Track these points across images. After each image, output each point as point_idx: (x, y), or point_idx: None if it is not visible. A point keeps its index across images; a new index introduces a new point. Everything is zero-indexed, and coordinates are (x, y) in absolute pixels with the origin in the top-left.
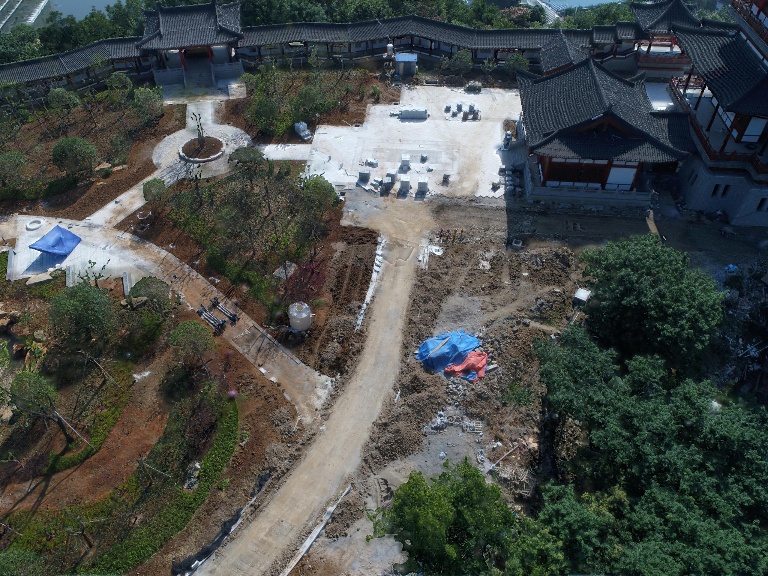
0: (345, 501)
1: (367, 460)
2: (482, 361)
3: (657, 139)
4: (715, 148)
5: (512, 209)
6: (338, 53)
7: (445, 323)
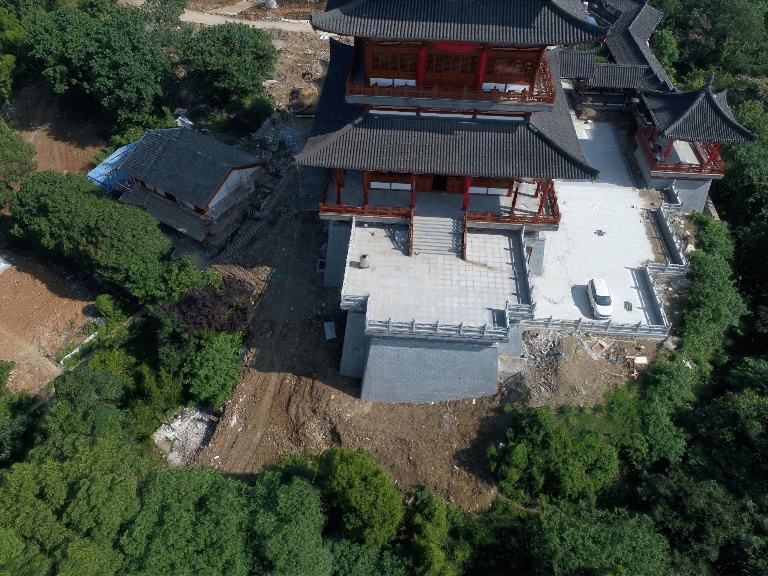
0: None
1: None
2: None
3: None
4: None
5: None
6: (601, 6)
7: None
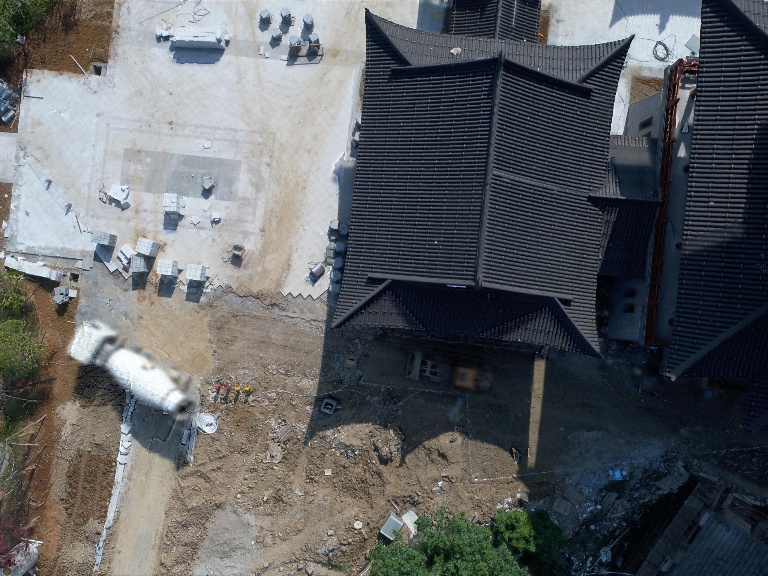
0: None
1: None
2: None
3: (563, 310)
4: (669, 305)
5: None
6: None
7: (209, 559)
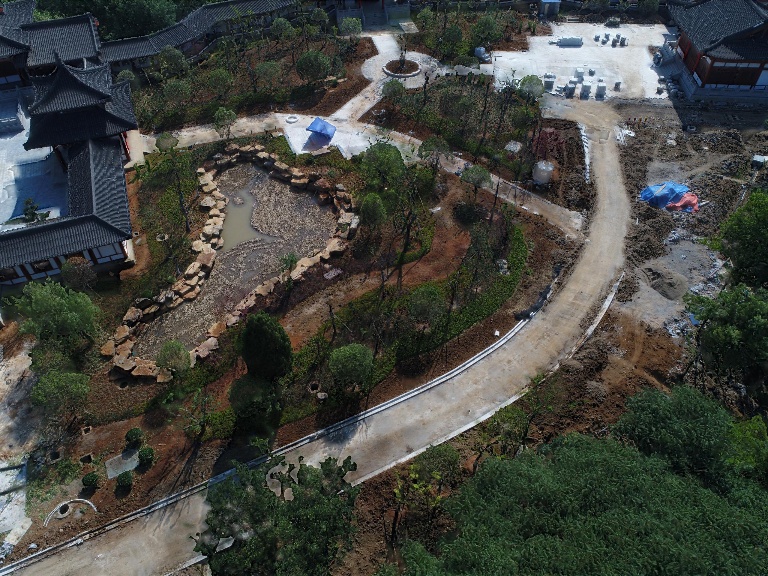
0: (626, 279)
1: (630, 258)
2: (695, 200)
3: None
4: None
5: (679, 106)
6: None
7: (654, 179)
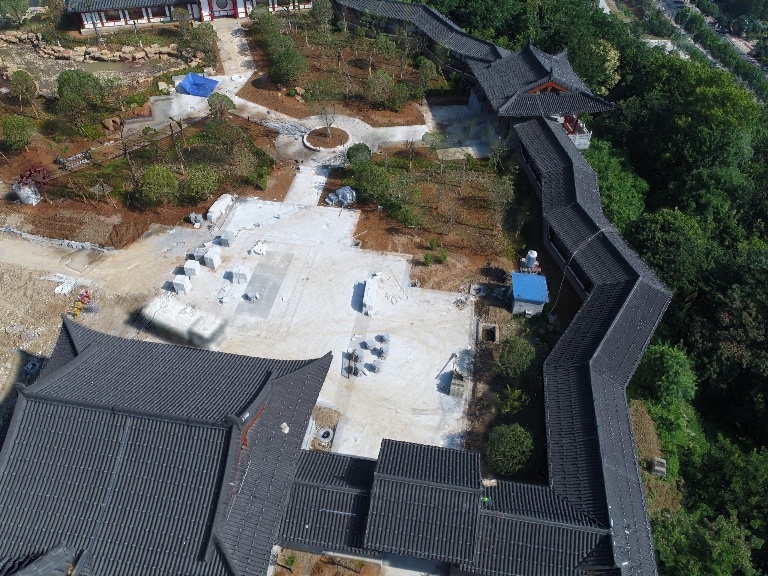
0: None
1: None
2: None
3: None
4: None
5: None
6: None
7: None
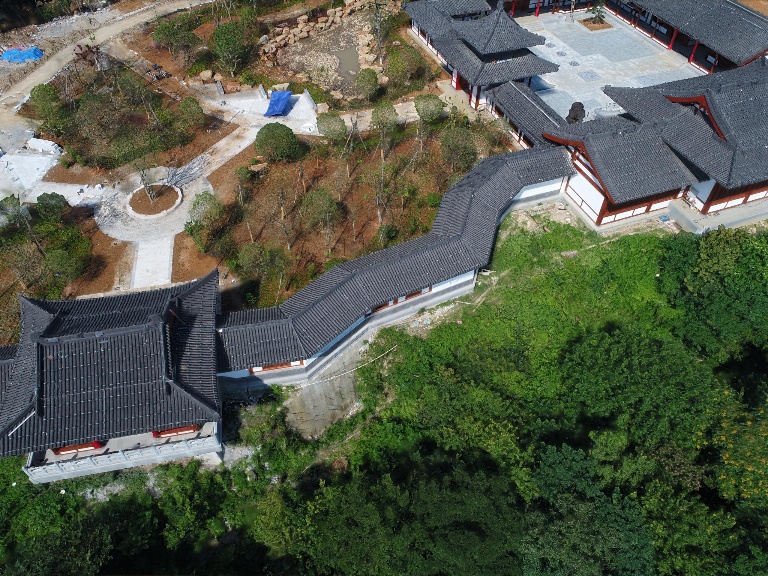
0: None
1: None
2: None
3: None
4: None
5: None
6: None
7: None
